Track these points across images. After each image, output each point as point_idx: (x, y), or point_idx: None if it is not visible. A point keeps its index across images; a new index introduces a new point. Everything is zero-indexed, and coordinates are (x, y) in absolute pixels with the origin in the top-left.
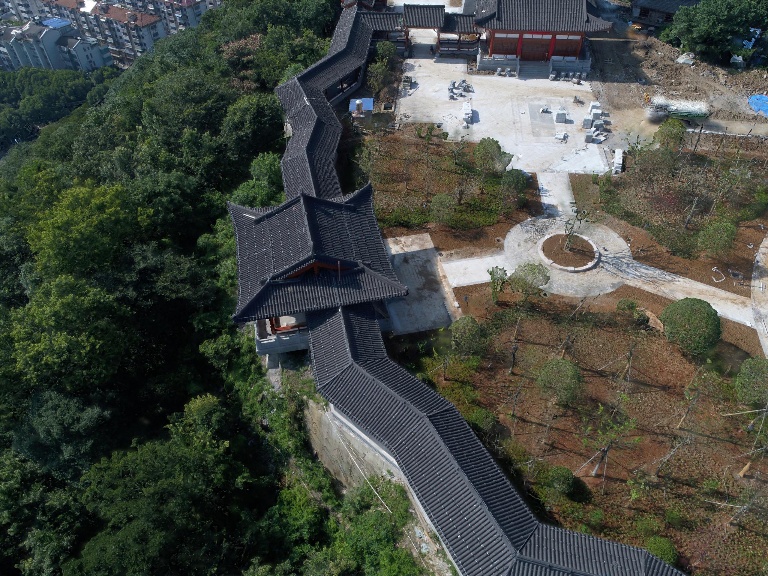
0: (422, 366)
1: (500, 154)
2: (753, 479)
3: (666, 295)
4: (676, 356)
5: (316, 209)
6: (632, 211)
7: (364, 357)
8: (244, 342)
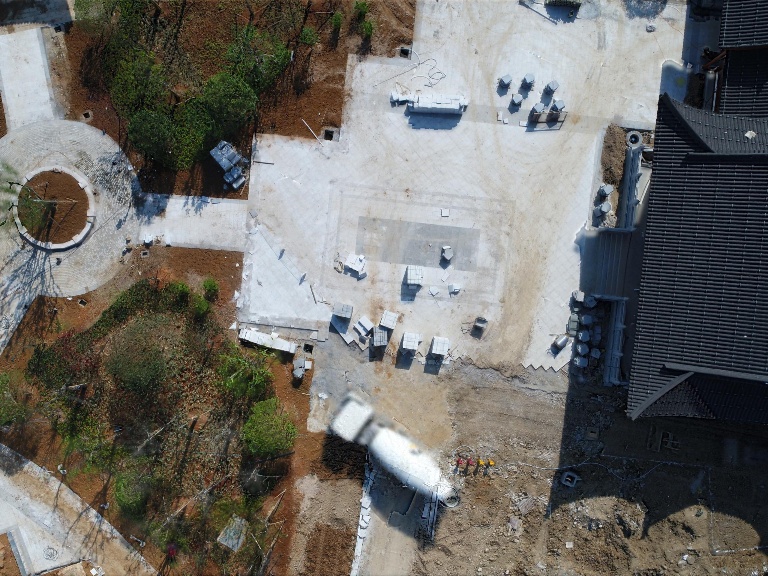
0: None
1: None
2: None
3: None
4: None
5: None
6: None
7: None
8: None
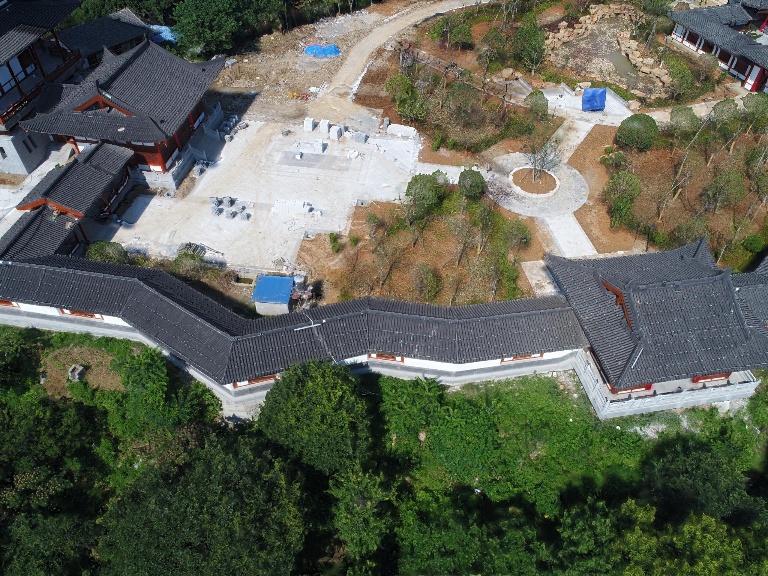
0: None
1: (435, 178)
2: None
3: (574, 149)
4: (641, 155)
5: None
6: (480, 139)
7: None
8: (714, 427)
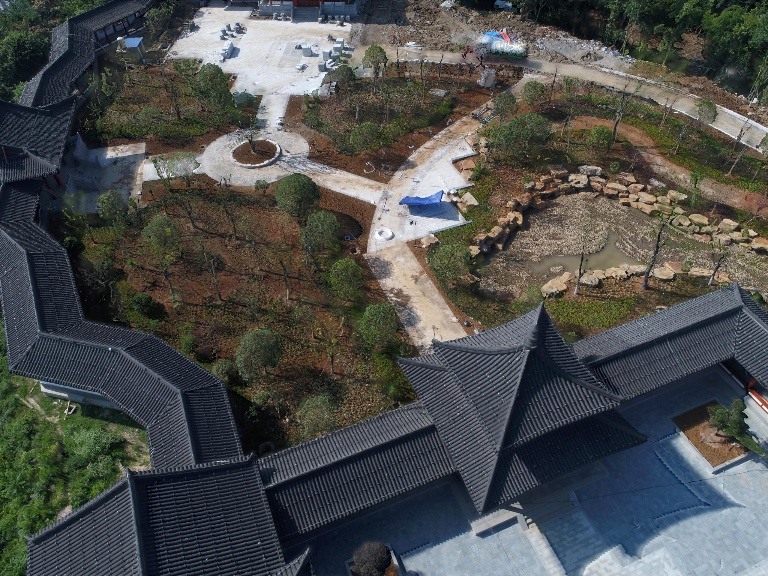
0: (82, 234)
1: (217, 76)
2: (296, 301)
3: (318, 183)
4: (293, 223)
5: (8, 112)
6: (324, 122)
7: (8, 218)
8: None
